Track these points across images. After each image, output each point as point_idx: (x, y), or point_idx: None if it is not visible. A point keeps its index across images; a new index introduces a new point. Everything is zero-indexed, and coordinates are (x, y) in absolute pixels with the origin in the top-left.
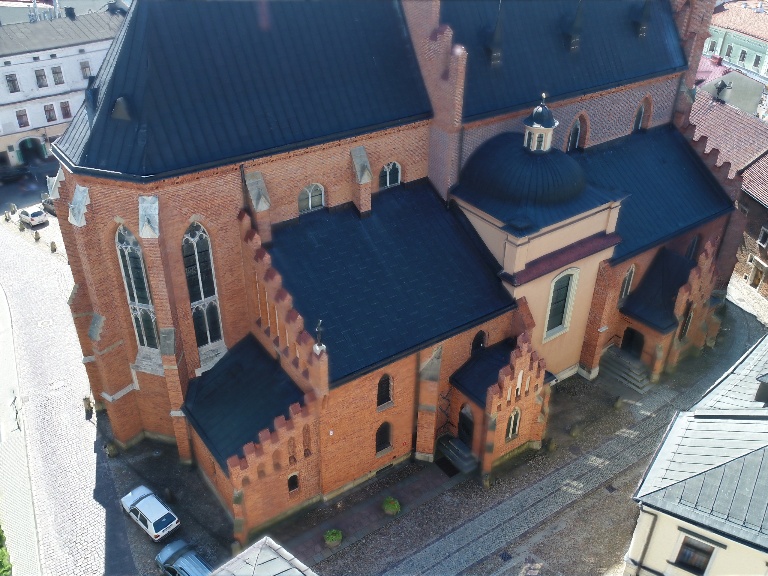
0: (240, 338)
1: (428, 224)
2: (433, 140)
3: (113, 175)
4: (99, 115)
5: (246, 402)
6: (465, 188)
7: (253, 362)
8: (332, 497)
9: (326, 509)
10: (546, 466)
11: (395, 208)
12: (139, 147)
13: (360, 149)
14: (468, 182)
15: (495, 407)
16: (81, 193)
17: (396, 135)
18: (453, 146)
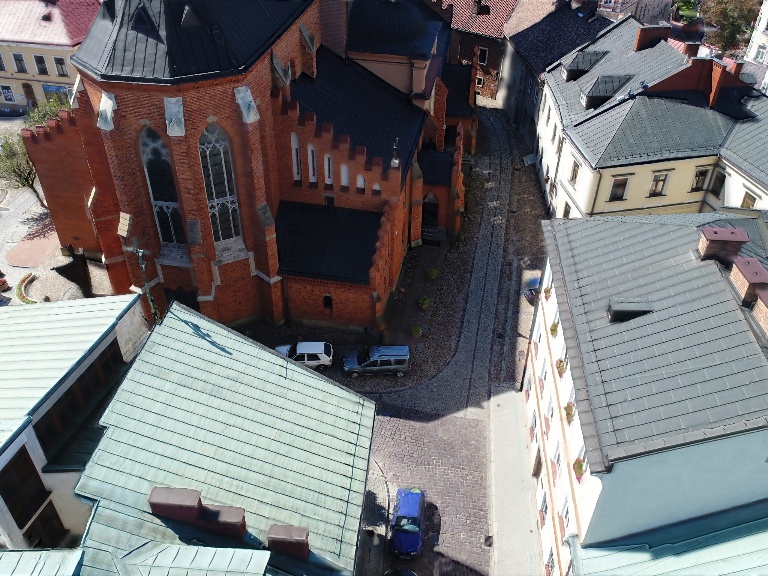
0: (277, 208)
1: (347, 77)
2: (325, 11)
3: (212, 75)
4: (166, 28)
5: (329, 241)
6: (355, 44)
7: (304, 217)
8: (395, 288)
9: (399, 296)
10: (475, 218)
11: (323, 71)
12: (220, 46)
13: (303, 25)
14: (356, 38)
15: (457, 181)
16: (175, 104)
17: (310, 10)
18: (344, 11)
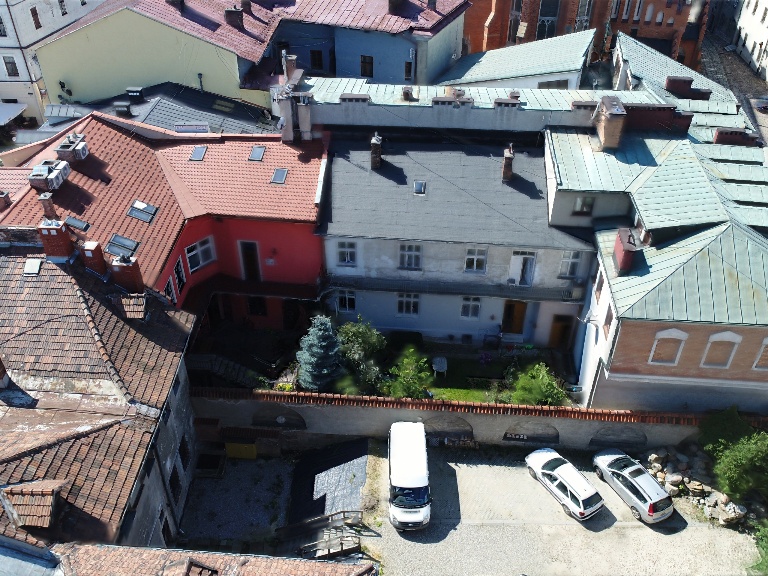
0: None
1: None
2: None
3: None
4: None
5: None
6: None
7: None
8: None
9: None
10: None
11: None
12: None
13: None
14: None
15: None
16: None
17: None
18: None
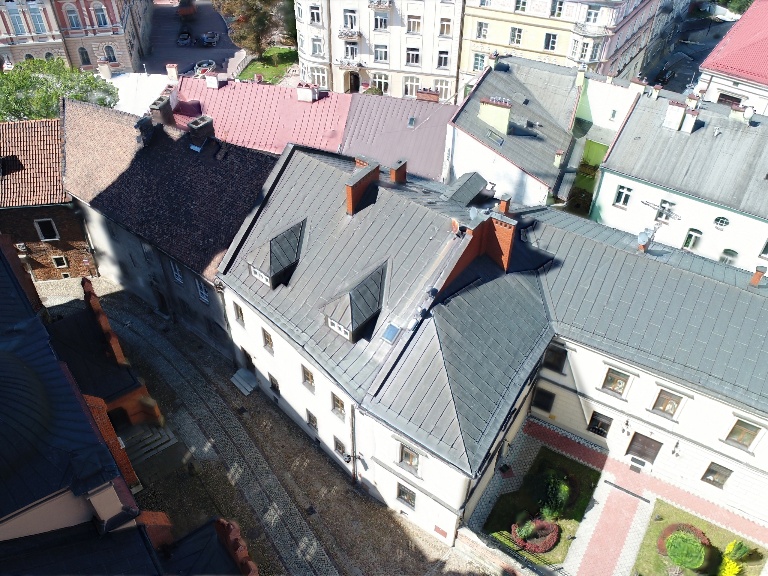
0: None
1: None
2: None
3: None
4: None
5: None
6: None
7: None
8: None
9: None
10: (275, 571)
11: None
12: None
13: None
14: None
15: None
16: None
17: None
18: None
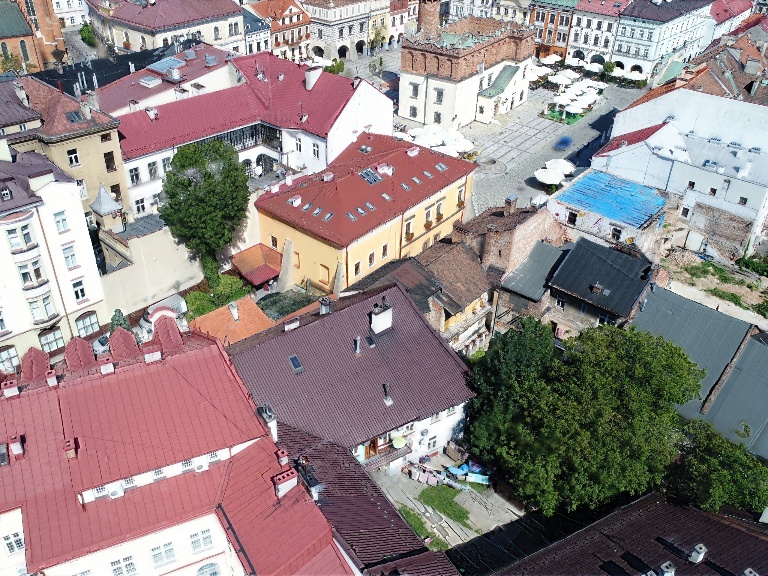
0: None
1: None
2: None
3: None
4: None
5: None
6: None
7: None
8: None
9: None
10: None
11: None
12: None
13: None
14: None
15: None
16: None
17: None
18: None
